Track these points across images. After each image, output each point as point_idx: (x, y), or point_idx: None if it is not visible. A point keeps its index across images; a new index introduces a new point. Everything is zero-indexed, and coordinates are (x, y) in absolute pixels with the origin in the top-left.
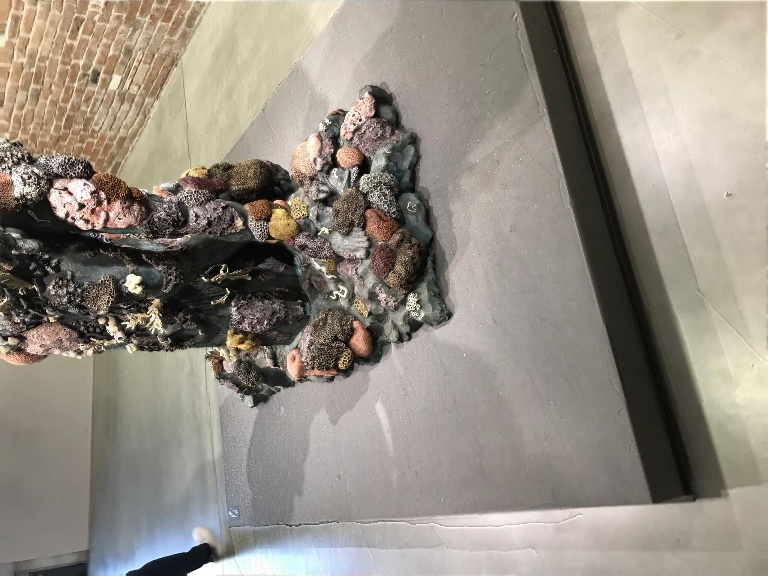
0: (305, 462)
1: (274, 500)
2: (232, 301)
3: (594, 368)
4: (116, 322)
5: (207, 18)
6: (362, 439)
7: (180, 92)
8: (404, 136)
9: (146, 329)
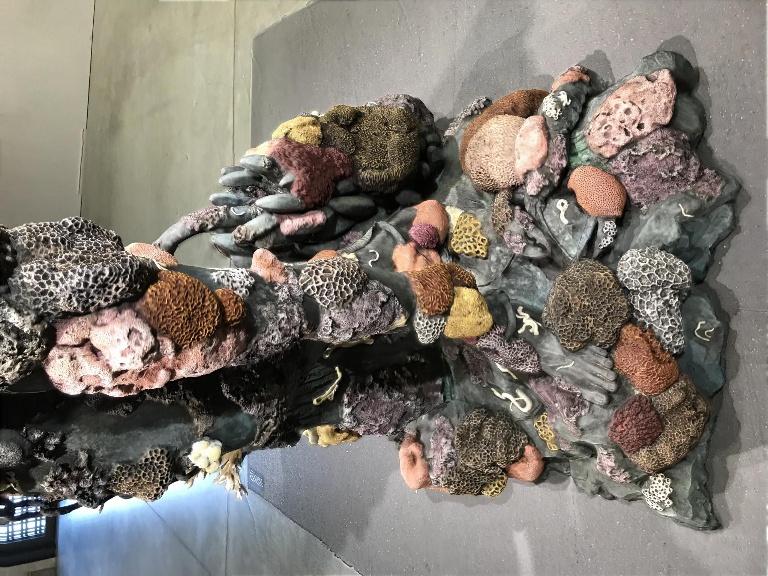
0: (374, 508)
1: (317, 511)
2: (344, 394)
3: None
4: None
5: None
6: (478, 555)
7: None
8: (725, 189)
9: None
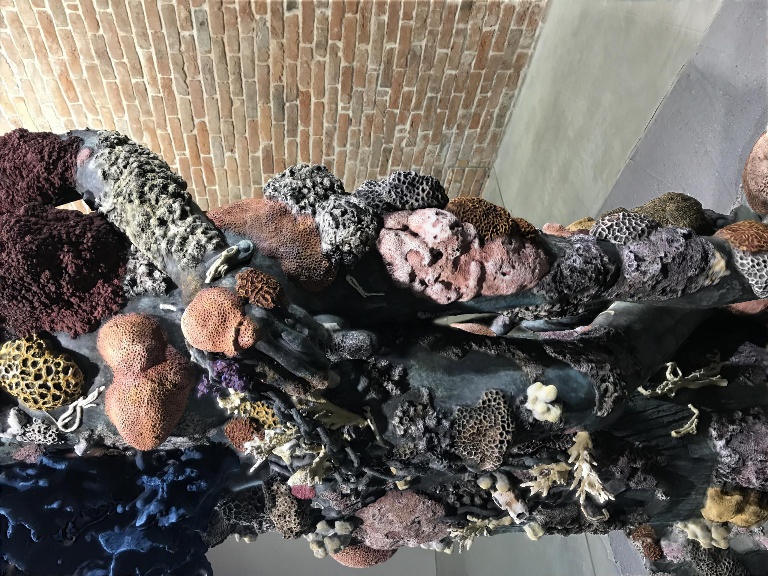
0: None
1: None
2: (710, 428)
3: None
4: (510, 483)
5: (519, 109)
6: None
7: (497, 202)
8: None
9: (561, 494)
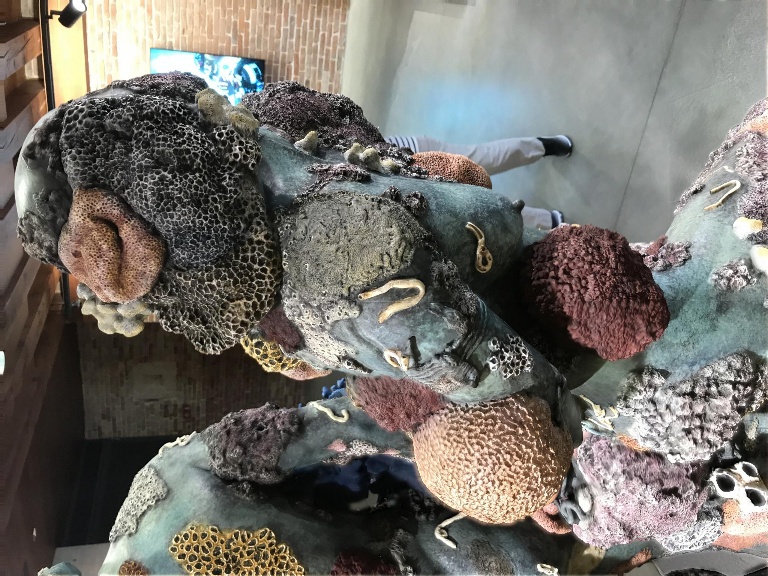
0: None
1: None
2: None
3: (685, 567)
4: None
5: None
6: None
7: None
8: None
9: None
